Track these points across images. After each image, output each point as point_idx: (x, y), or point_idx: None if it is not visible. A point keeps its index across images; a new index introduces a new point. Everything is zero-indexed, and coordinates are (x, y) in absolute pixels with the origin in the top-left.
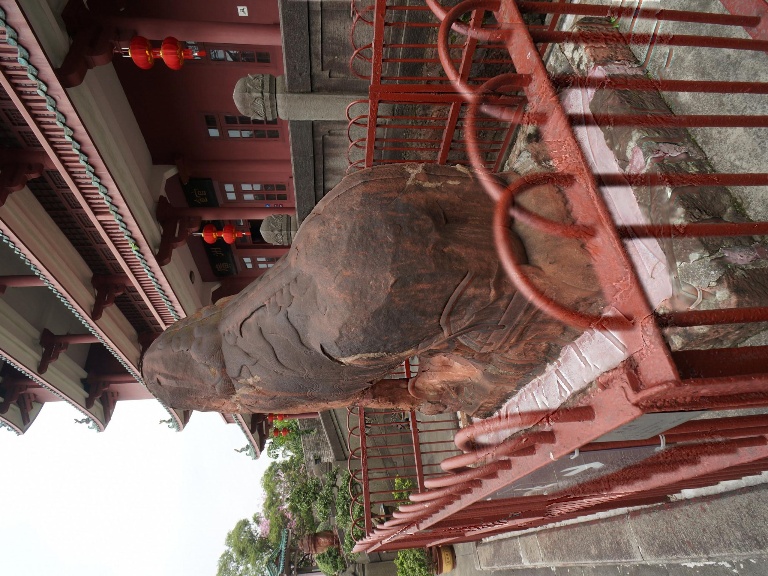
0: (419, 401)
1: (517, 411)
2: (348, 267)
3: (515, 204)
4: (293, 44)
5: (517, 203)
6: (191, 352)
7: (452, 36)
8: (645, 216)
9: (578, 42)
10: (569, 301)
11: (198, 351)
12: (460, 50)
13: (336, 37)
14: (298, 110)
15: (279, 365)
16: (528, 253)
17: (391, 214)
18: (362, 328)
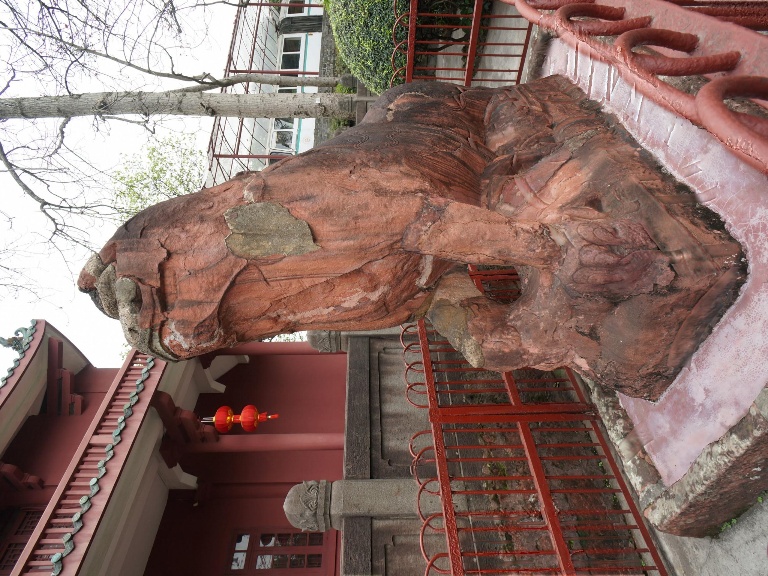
0: None
1: (670, 141)
2: None
3: None
4: None
5: None
6: None
7: None
8: (533, 79)
9: None
10: None
11: None
12: None
13: None
14: None
15: None
16: None
17: None
18: None
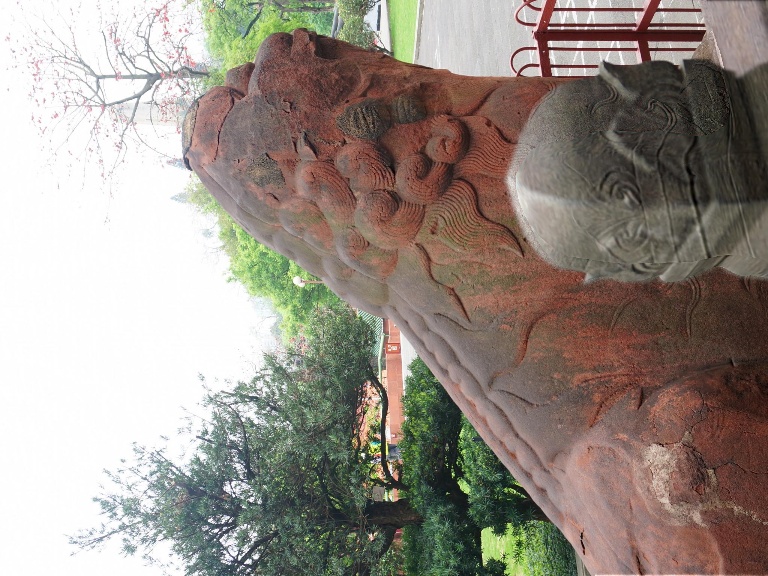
0: None
1: None
2: None
3: None
4: None
5: None
6: None
7: None
8: None
9: None
10: None
11: None
12: None
13: None
14: None
15: None
16: None
17: None
18: None
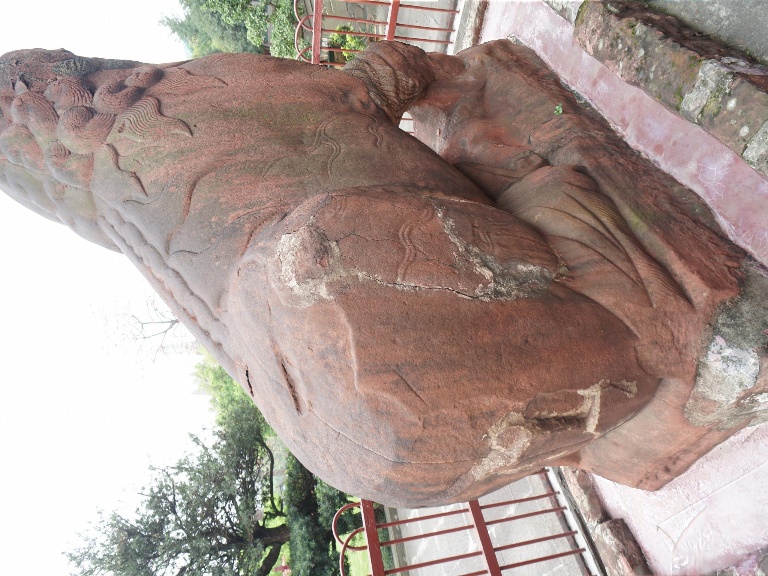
0: None
1: None
2: None
3: None
4: None
5: None
6: None
7: None
8: (705, 573)
9: None
10: None
11: None
12: None
13: None
14: None
15: None
16: None
17: None
18: None
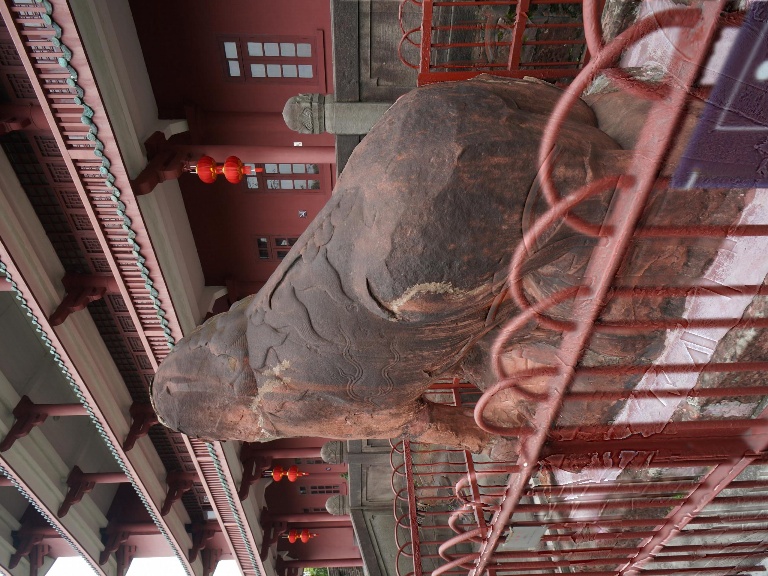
0: (490, 436)
1: (628, 432)
2: (403, 150)
3: (597, 114)
4: (343, 48)
5: (599, 112)
6: (210, 345)
7: (499, 33)
8: None
9: None
10: (694, 186)
11: (218, 340)
12: (508, 48)
13: (384, 42)
14: (345, 122)
15: (313, 335)
16: (625, 148)
17: (453, 95)
18: (421, 227)
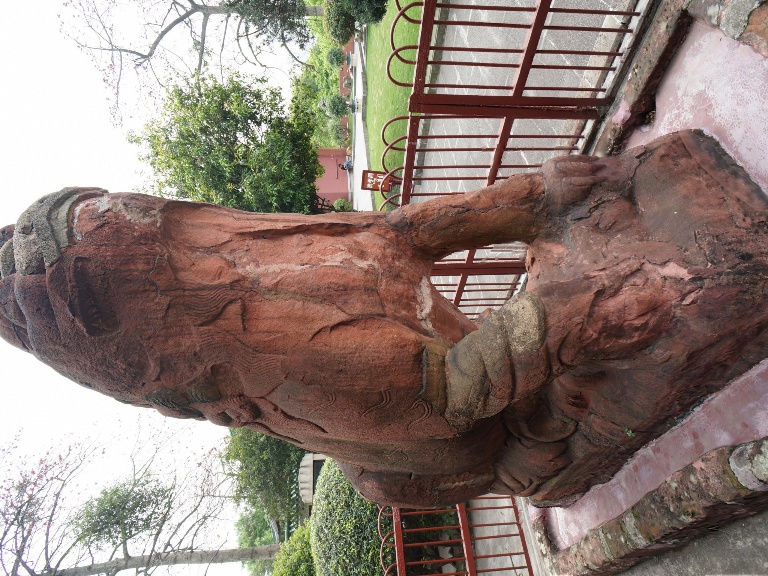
0: None
1: None
2: None
3: None
4: None
5: None
6: None
7: None
8: None
9: (541, 555)
10: None
11: None
12: None
13: None
14: None
15: None
16: None
17: None
18: None
